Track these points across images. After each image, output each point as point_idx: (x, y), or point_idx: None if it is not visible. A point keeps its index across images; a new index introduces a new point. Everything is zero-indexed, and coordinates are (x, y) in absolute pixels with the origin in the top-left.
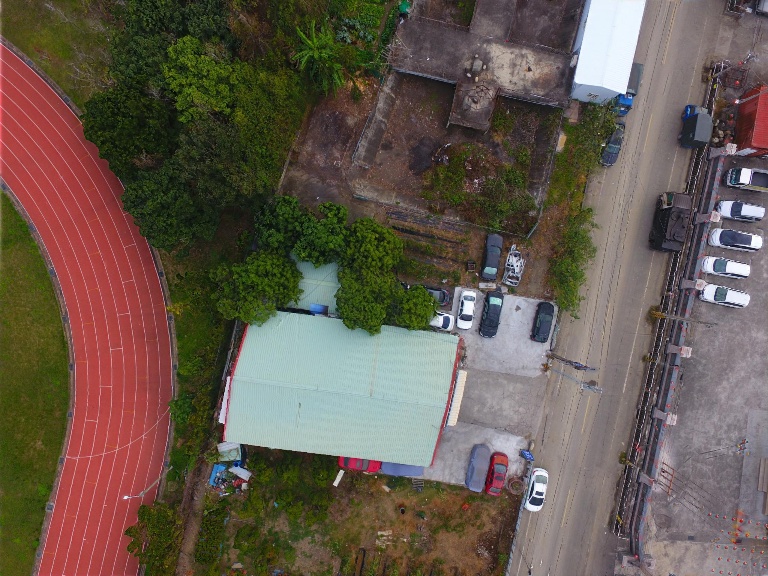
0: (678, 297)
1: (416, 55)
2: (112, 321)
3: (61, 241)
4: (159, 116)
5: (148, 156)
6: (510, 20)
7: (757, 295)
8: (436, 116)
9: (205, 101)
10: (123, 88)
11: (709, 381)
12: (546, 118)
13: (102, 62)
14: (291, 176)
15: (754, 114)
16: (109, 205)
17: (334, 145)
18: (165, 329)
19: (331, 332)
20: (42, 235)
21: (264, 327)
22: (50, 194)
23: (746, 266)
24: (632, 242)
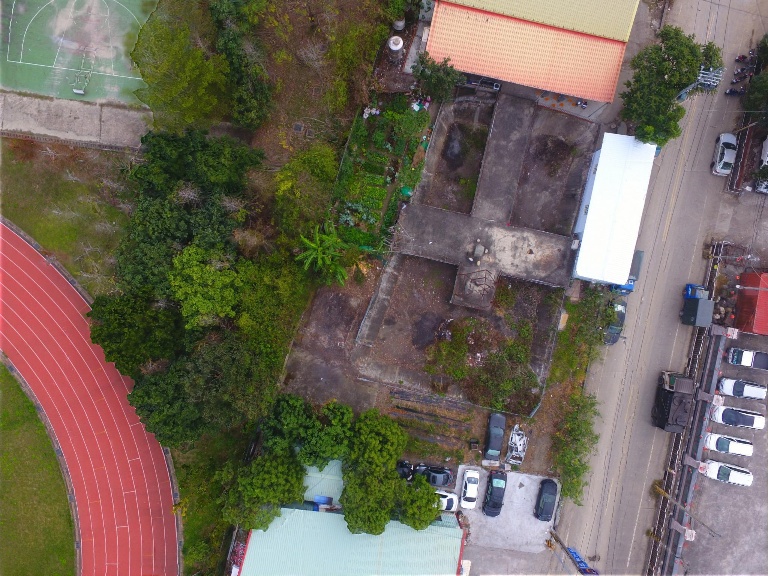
0: (681, 472)
1: (418, 239)
2: (118, 499)
3: (68, 421)
4: (165, 324)
5: (154, 364)
6: (511, 203)
7: (760, 469)
8: (438, 291)
9: (210, 309)
10: (129, 298)
11: (713, 555)
12: (548, 295)
13: (108, 245)
14: (295, 357)
15: (755, 300)
16: (115, 385)
17: (338, 326)
18: (170, 506)
19: (336, 529)
20: (49, 415)
21: (269, 527)
22: (57, 375)
23: (749, 446)
24: (635, 417)
